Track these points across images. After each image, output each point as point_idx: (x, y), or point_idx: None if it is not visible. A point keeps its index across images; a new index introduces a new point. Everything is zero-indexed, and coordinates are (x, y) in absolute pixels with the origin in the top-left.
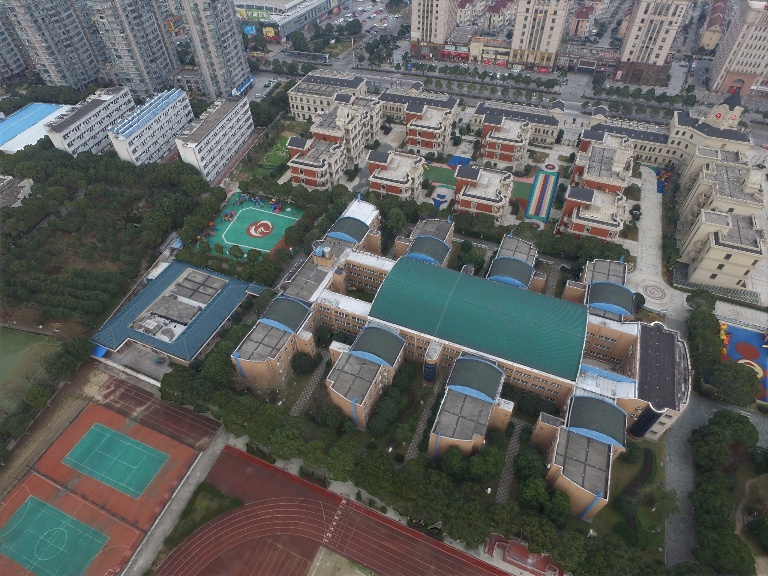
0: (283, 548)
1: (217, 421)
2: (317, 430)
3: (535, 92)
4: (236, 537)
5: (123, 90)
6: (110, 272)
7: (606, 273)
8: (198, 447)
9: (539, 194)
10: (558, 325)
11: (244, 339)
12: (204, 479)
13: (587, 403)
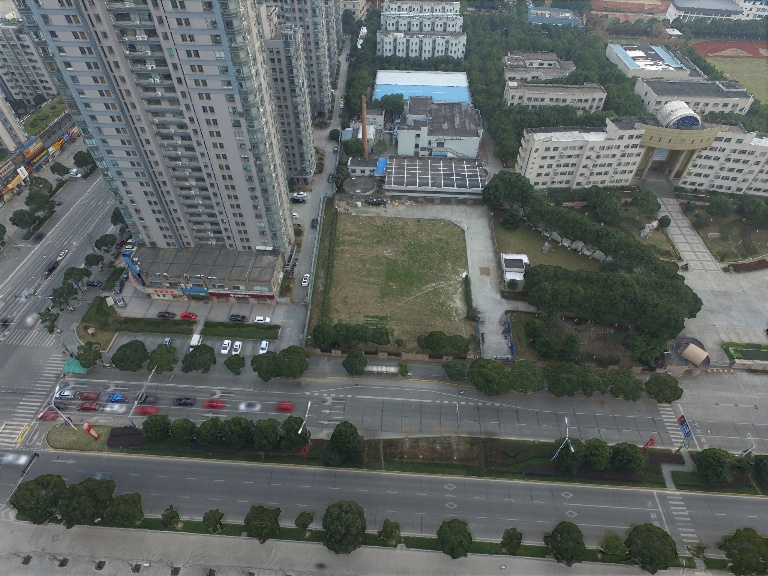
0: (608, 3)
1: None
2: None
3: None
4: (612, 7)
5: (384, 31)
6: (550, 25)
7: None
8: None
9: None
10: None
11: None
12: None
13: None
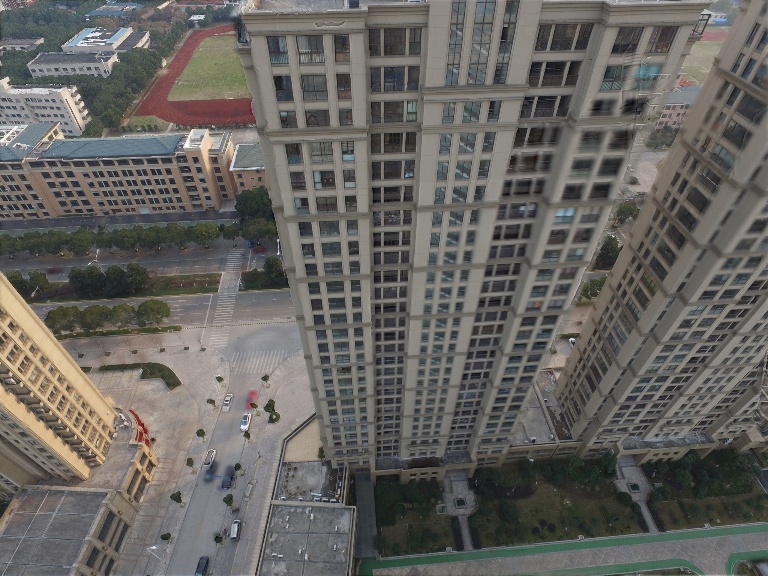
0: None
1: (167, 6)
2: None
3: None
4: None
5: None
6: None
7: None
8: (176, 6)
9: None
10: None
11: None
12: (186, 4)
13: None
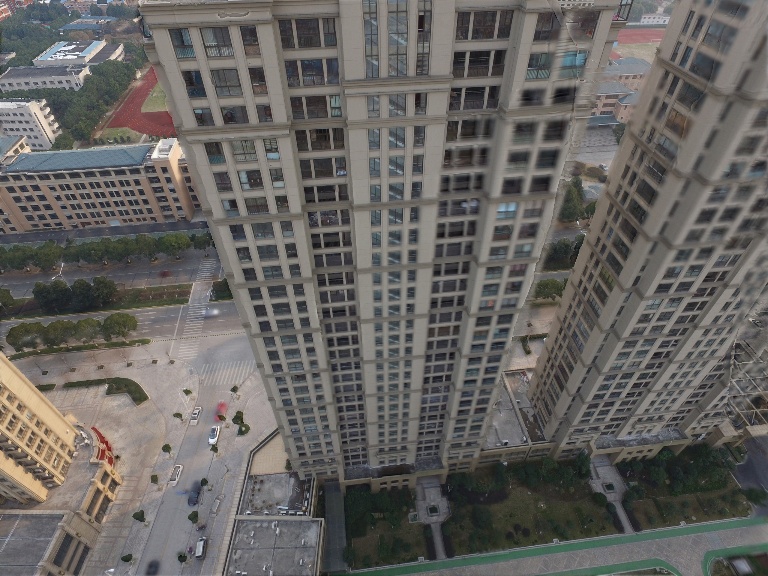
0: None
1: None
2: None
3: None
4: None
5: None
6: None
7: None
8: None
9: None
10: None
11: (115, 3)
12: None
13: None
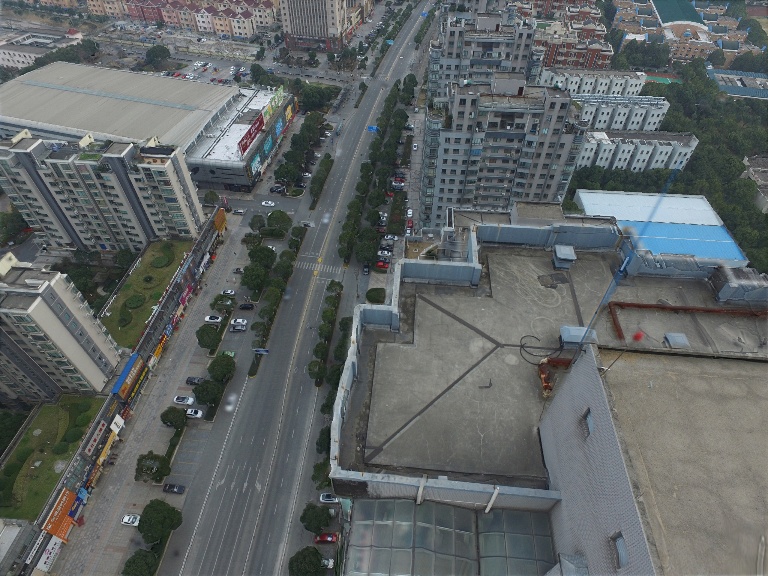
0: None
1: None
2: (758, 45)
3: (409, 18)
4: None
5: None
6: (759, 102)
7: (623, 0)
8: None
9: (545, 22)
10: (674, 0)
11: None
12: None
13: (698, 4)
